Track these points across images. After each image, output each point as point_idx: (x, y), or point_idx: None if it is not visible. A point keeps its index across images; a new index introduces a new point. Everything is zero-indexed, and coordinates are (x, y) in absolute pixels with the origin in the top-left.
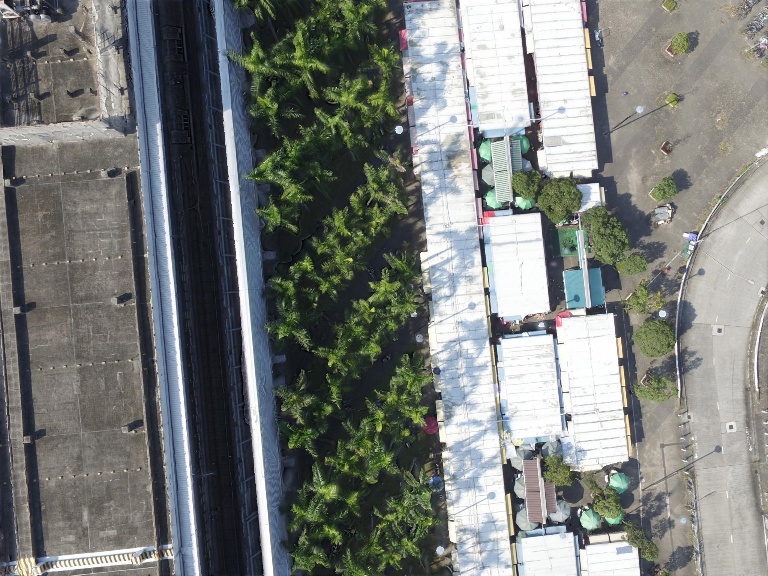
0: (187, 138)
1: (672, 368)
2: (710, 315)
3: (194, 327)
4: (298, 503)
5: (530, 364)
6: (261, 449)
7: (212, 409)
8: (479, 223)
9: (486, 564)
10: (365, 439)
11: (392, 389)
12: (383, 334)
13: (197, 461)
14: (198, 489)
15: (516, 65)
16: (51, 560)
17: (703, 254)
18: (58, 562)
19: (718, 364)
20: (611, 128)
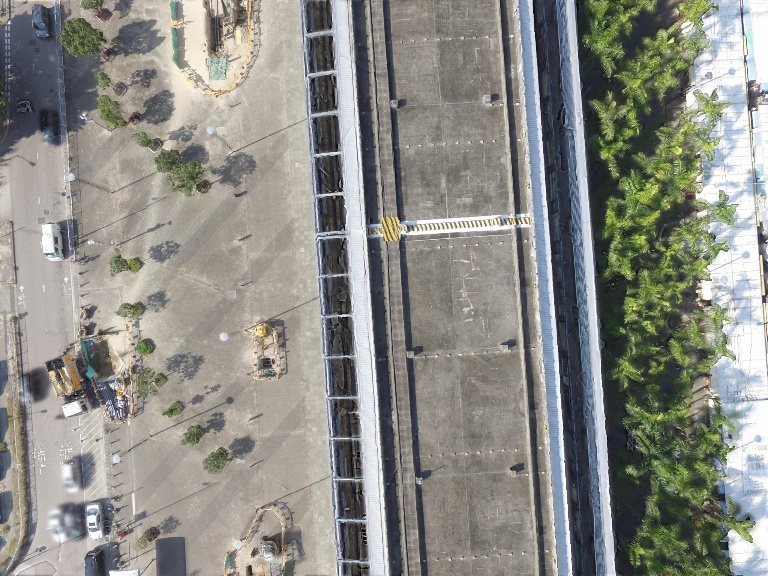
0: None
1: None
2: None
3: None
4: None
5: None
6: (584, 150)
7: None
8: None
9: (739, 320)
10: (663, 163)
11: (683, 122)
12: None
13: None
14: None
15: None
16: (410, 224)
17: None
18: (418, 225)
19: None
20: None
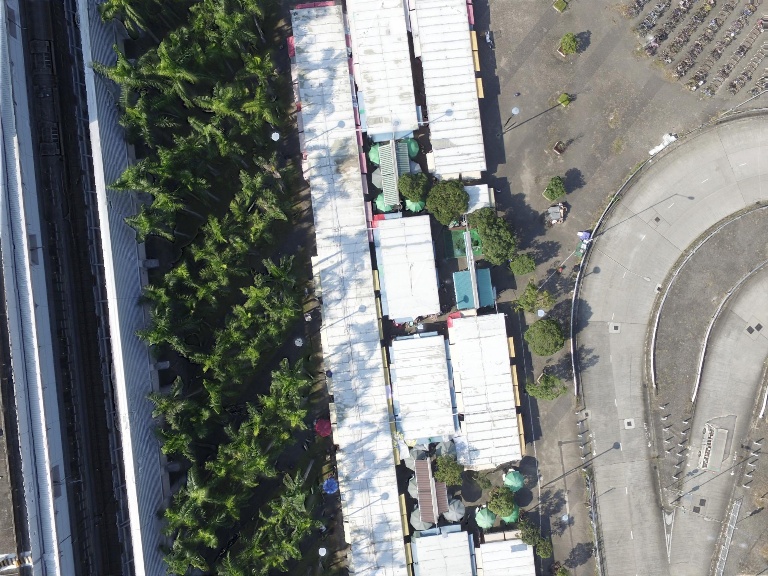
0: (56, 150)
1: (568, 366)
2: (606, 313)
3: (75, 336)
4: (173, 508)
5: (421, 365)
6: (131, 455)
7: (95, 416)
8: (369, 226)
9: (381, 564)
10: (243, 443)
11: (272, 393)
12: (263, 339)
13: (75, 468)
14: (75, 496)
15: (403, 69)
16: None
17: (598, 252)
18: None
19: (615, 361)
20: (504, 129)
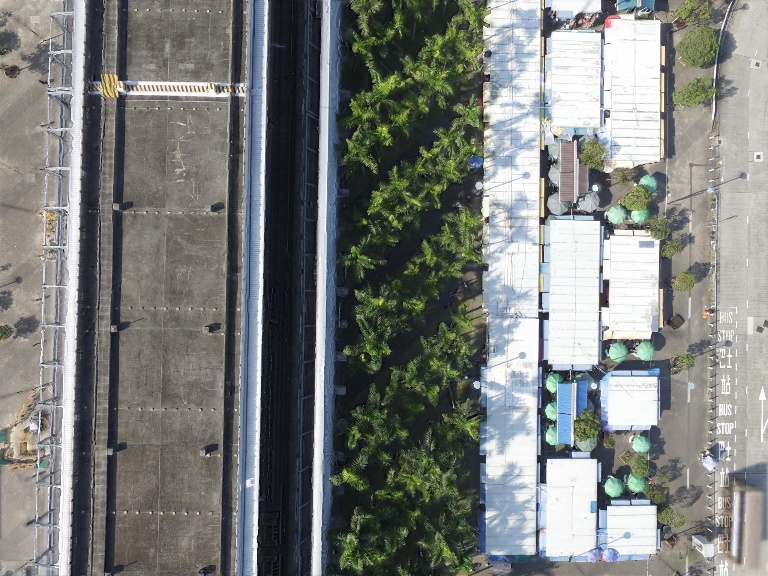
0: None
1: None
2: (750, 49)
3: None
4: None
5: (577, 57)
6: (329, 38)
7: (280, 30)
8: None
9: (515, 239)
10: (422, 65)
11: None
12: None
13: None
14: None
15: None
16: (131, 84)
17: None
18: (138, 85)
19: (753, 96)
20: None
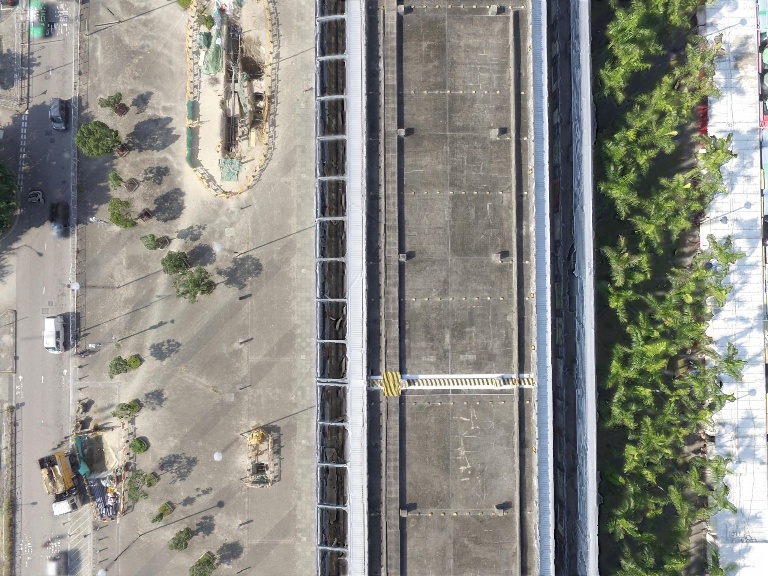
0: None
1: None
2: None
3: None
4: None
5: None
6: (593, 301)
7: None
8: (760, 125)
9: (742, 459)
10: (672, 310)
11: (695, 267)
12: (687, 214)
13: None
14: None
15: None
16: (411, 378)
17: None
18: (420, 380)
19: None
20: None
